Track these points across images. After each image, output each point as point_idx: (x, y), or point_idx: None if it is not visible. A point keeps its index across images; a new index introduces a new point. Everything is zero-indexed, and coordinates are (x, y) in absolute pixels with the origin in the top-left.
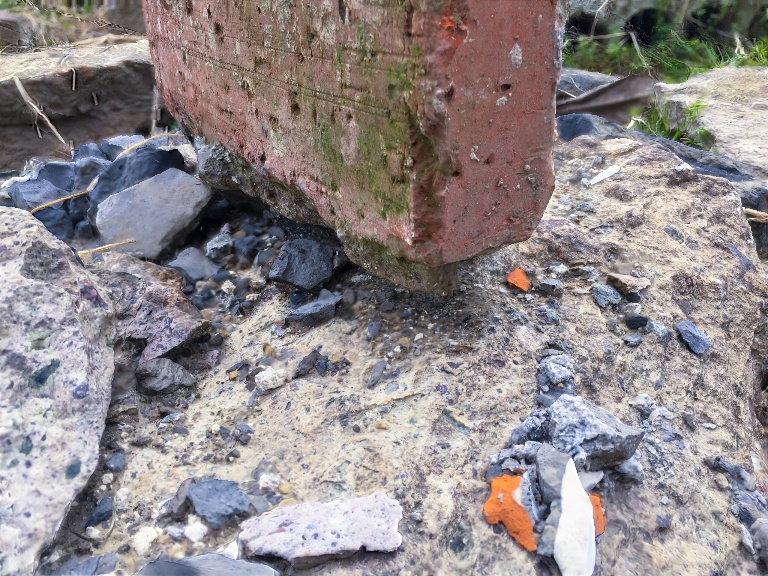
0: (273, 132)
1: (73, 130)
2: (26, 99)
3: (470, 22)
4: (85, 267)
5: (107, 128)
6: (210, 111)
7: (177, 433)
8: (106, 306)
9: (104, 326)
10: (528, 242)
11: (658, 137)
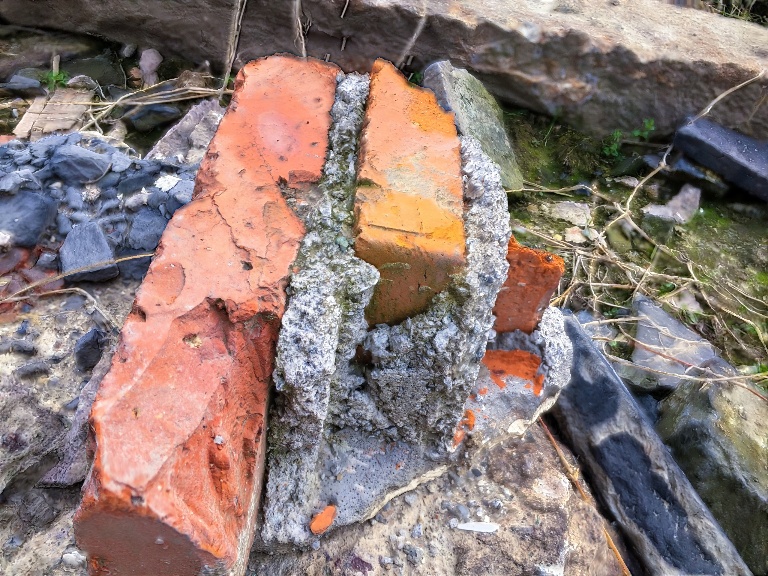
0: None
1: (334, 46)
2: (298, 15)
3: (111, 569)
4: None
5: (360, 56)
6: None
7: (0, 564)
8: (21, 451)
9: (8, 467)
10: (320, 567)
11: (674, 464)
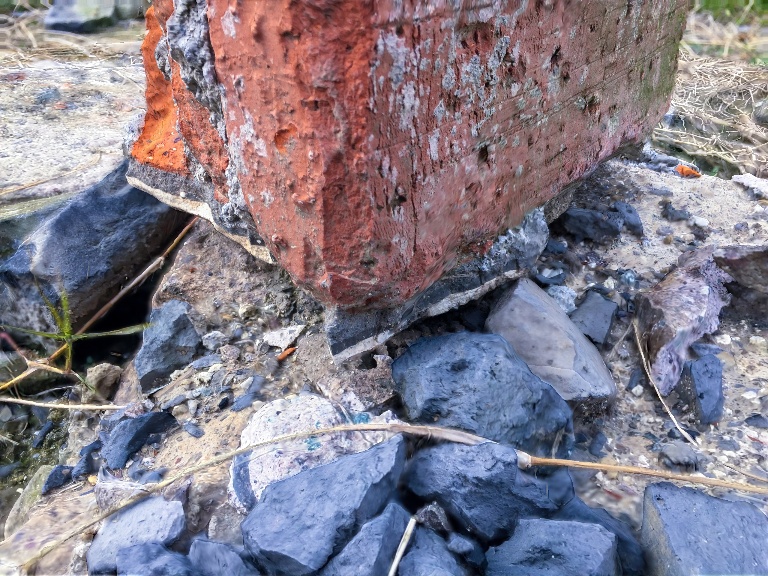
0: (610, 120)
1: None
2: None
3: None
4: (625, 457)
5: None
6: (528, 183)
7: None
8: None
9: None
10: None
11: None
